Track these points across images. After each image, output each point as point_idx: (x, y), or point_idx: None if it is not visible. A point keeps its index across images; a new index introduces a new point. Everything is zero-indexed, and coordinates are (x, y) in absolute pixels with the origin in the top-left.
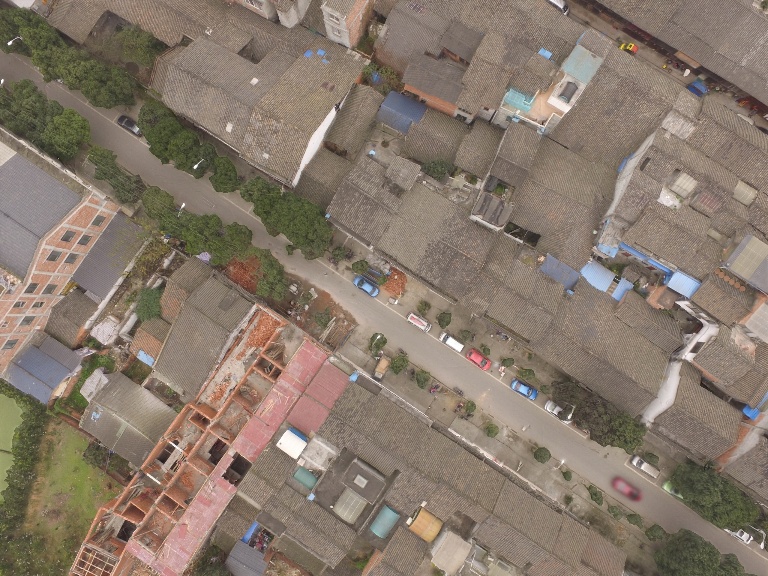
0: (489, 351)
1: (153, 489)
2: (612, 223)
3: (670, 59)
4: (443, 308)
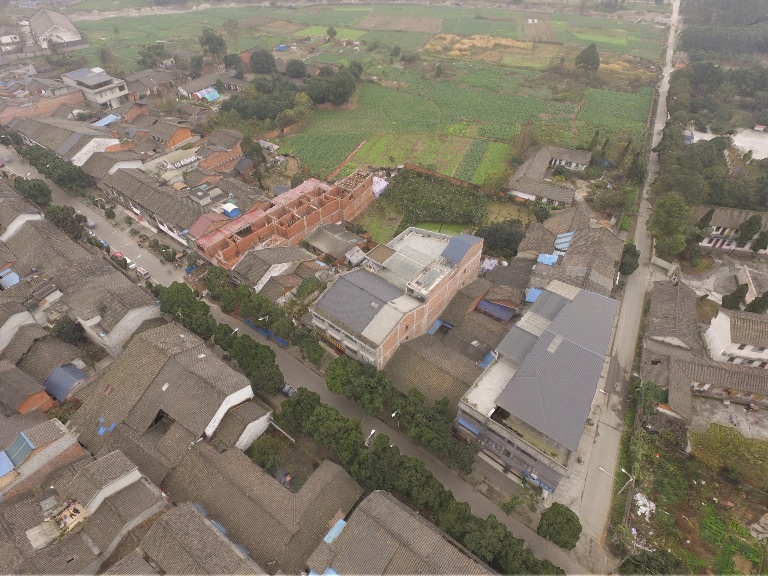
0: (105, 247)
1: None
2: None
3: None
4: None
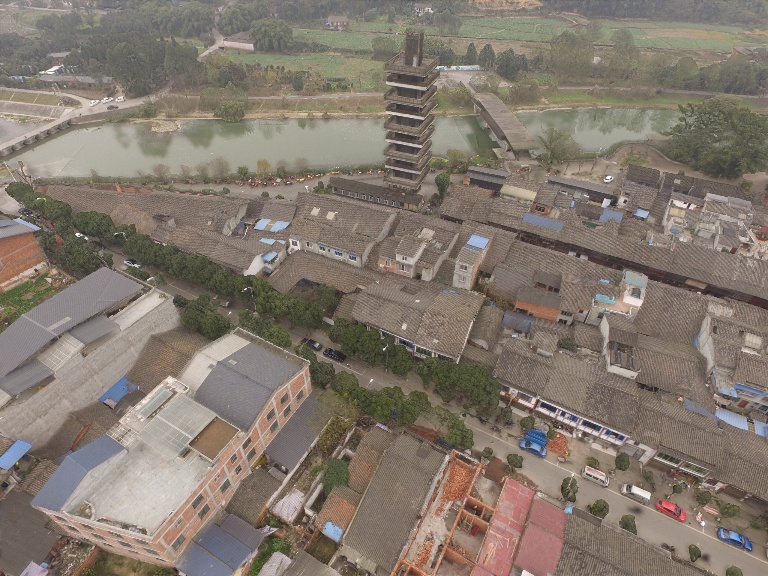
0: None
1: None
2: (718, 373)
3: (682, 288)
4: (611, 463)
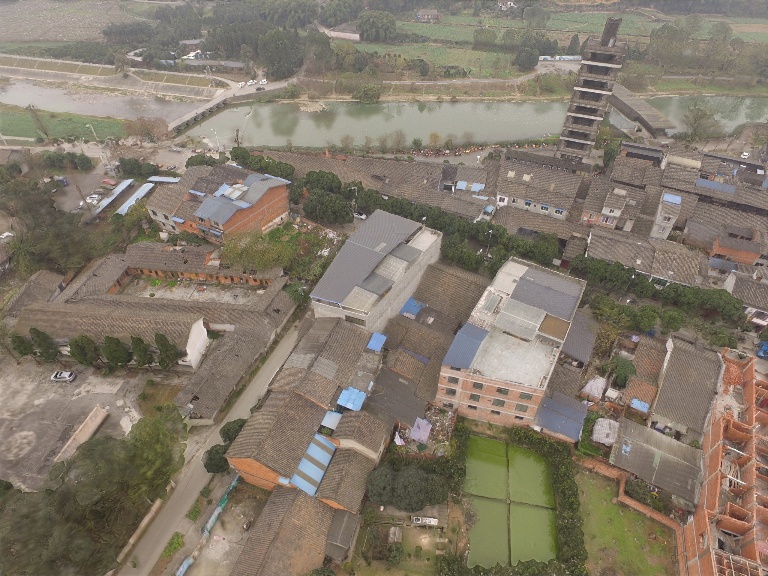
0: None
1: None
2: None
3: None
4: None
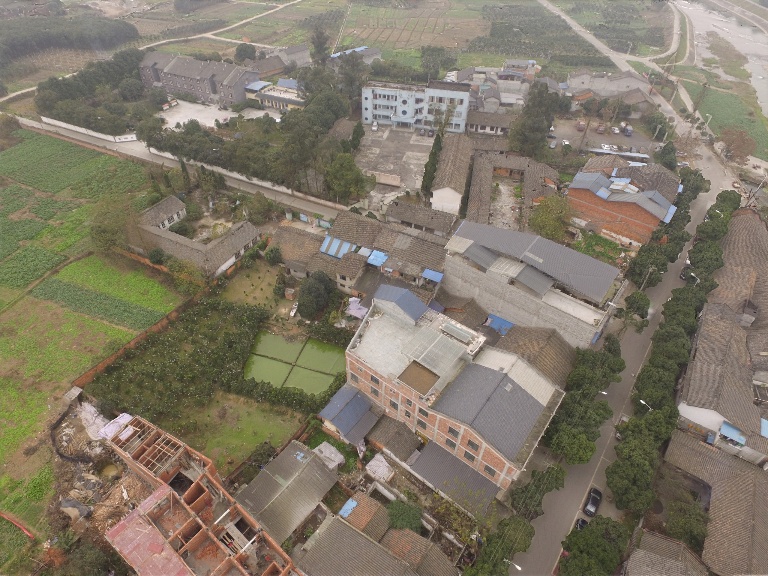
0: None
1: (213, 511)
2: None
3: None
4: None
